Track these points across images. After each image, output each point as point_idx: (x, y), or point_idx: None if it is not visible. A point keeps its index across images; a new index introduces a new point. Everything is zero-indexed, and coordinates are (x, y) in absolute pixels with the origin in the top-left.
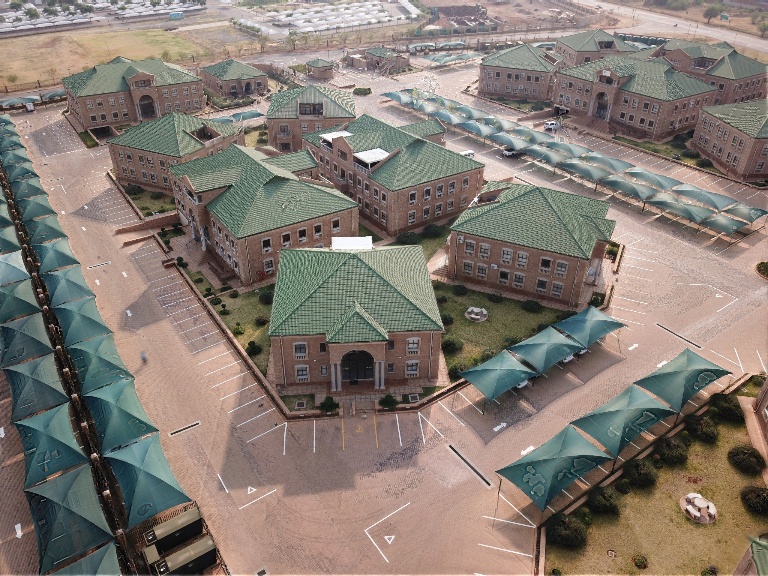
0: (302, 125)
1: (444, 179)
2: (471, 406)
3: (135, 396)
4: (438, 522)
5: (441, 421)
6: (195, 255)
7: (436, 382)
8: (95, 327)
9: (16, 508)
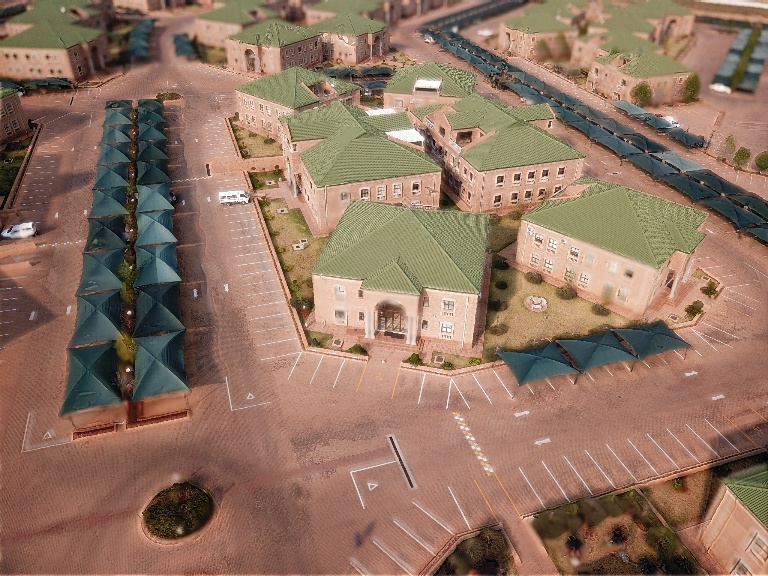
0: None
1: None
2: None
3: None
4: None
5: None
6: None
7: None
8: None
9: None
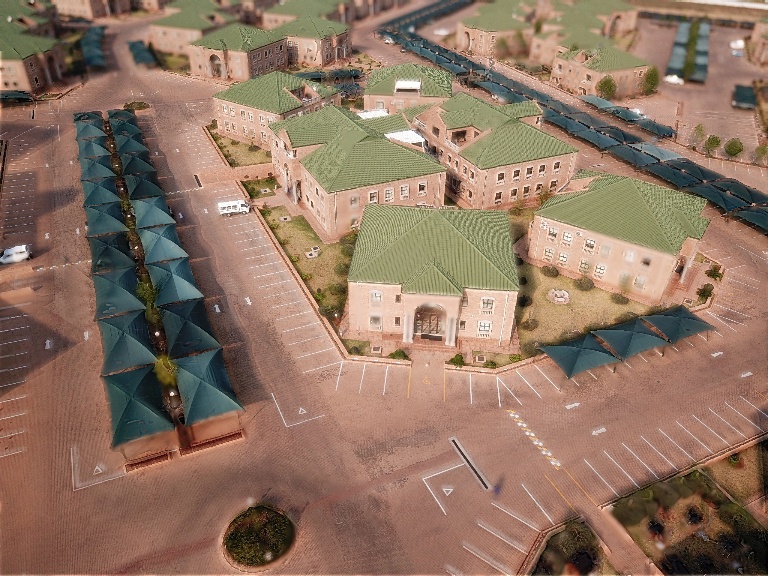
0: None
1: None
2: None
3: None
4: None
5: None
6: None
7: None
8: None
9: None
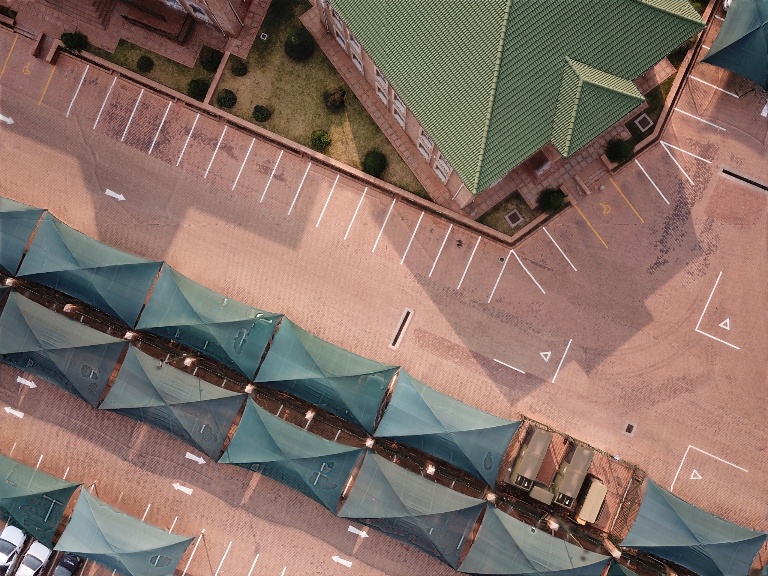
0: None
1: None
2: (718, 92)
3: (321, 343)
4: (763, 278)
5: (695, 139)
6: (74, 7)
7: (655, 77)
8: (134, 273)
9: (326, 516)
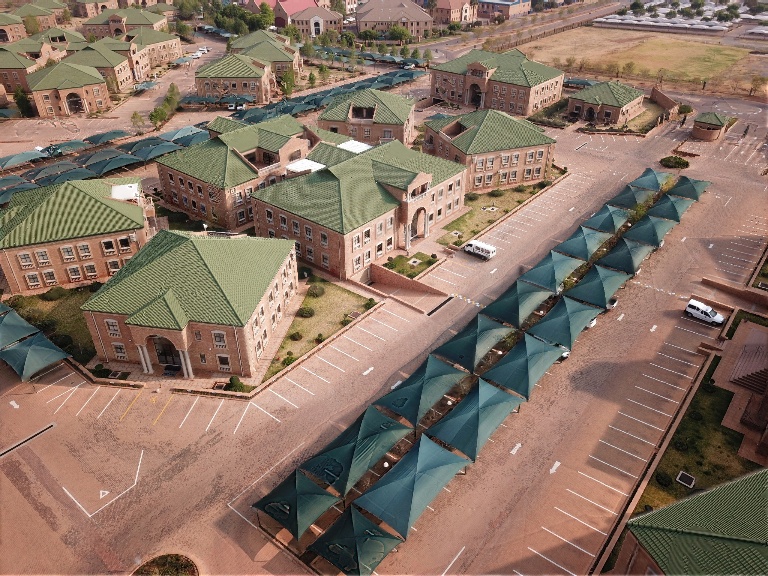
0: (440, 142)
1: (300, 218)
2: None
3: None
4: None
5: None
6: None
7: (8, 293)
8: None
9: None
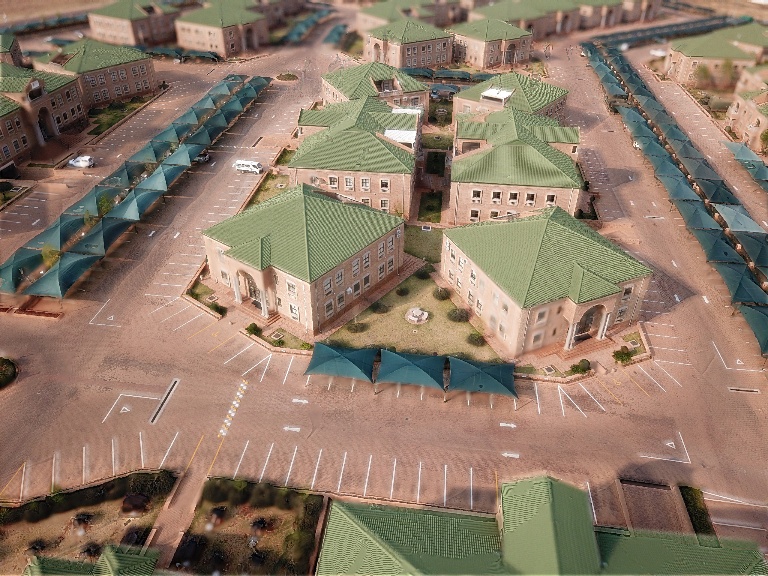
0: None
1: None
2: None
3: None
4: None
5: None
6: None
7: None
8: None
9: None
